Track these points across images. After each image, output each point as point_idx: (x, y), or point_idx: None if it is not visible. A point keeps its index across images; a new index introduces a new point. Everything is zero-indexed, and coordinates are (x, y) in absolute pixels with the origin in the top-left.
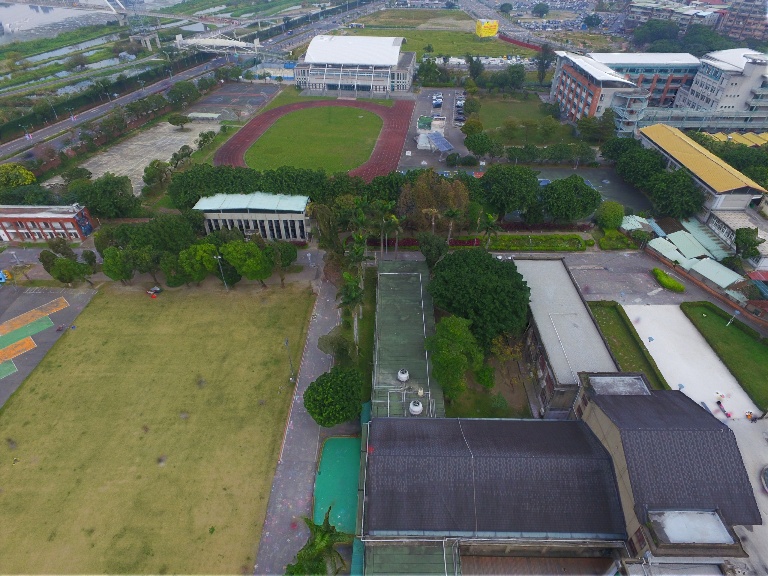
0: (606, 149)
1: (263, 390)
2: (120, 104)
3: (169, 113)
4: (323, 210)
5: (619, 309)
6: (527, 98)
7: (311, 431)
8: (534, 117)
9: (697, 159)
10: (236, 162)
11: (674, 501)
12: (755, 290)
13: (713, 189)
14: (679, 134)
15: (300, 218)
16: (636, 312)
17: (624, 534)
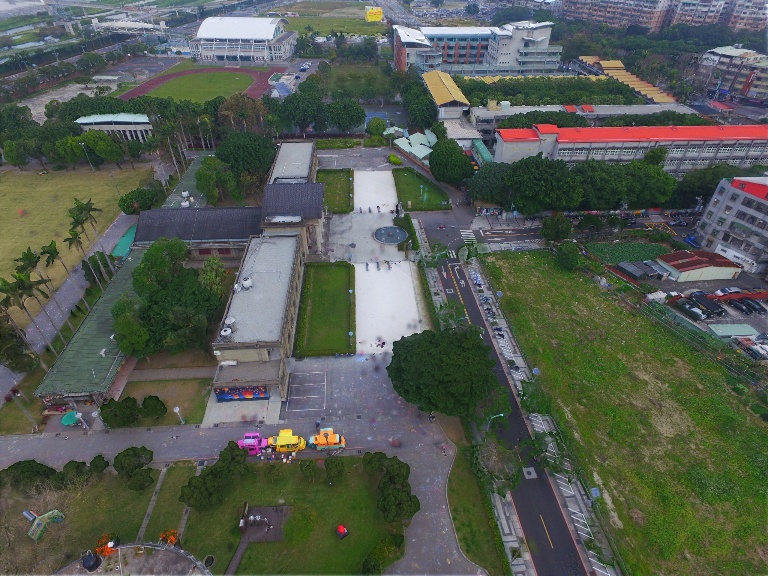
0: (401, 90)
1: (103, 211)
2: None
3: None
4: None
5: (350, 172)
6: (378, 64)
7: (127, 225)
8: None
9: (440, 88)
10: None
11: (281, 211)
12: None
13: None
14: (445, 76)
15: (151, 128)
16: (363, 174)
17: None
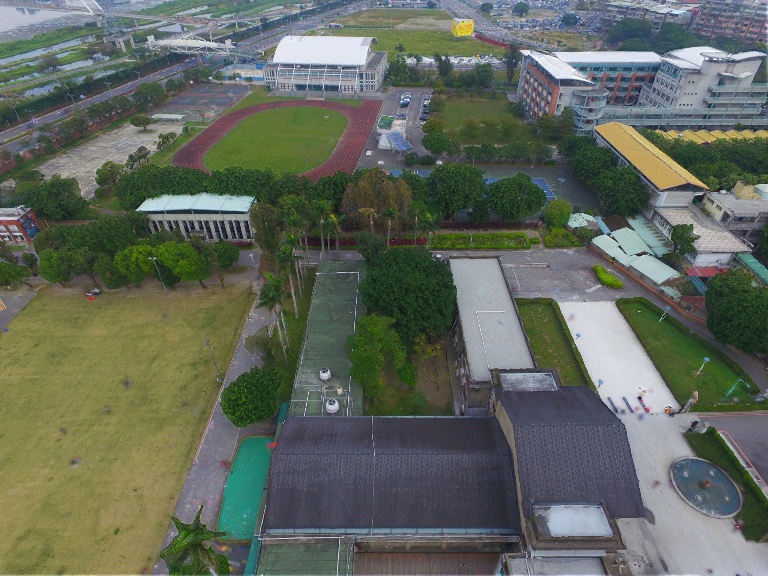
0: (562, 147)
1: (188, 391)
2: (85, 106)
3: (134, 114)
4: (268, 210)
5: (554, 306)
6: (494, 97)
7: (231, 431)
8: (499, 116)
9: (644, 157)
10: (195, 163)
11: (560, 495)
12: (690, 286)
13: (656, 186)
14: (632, 132)
15: (245, 218)
16: (572, 309)
17: (518, 529)
